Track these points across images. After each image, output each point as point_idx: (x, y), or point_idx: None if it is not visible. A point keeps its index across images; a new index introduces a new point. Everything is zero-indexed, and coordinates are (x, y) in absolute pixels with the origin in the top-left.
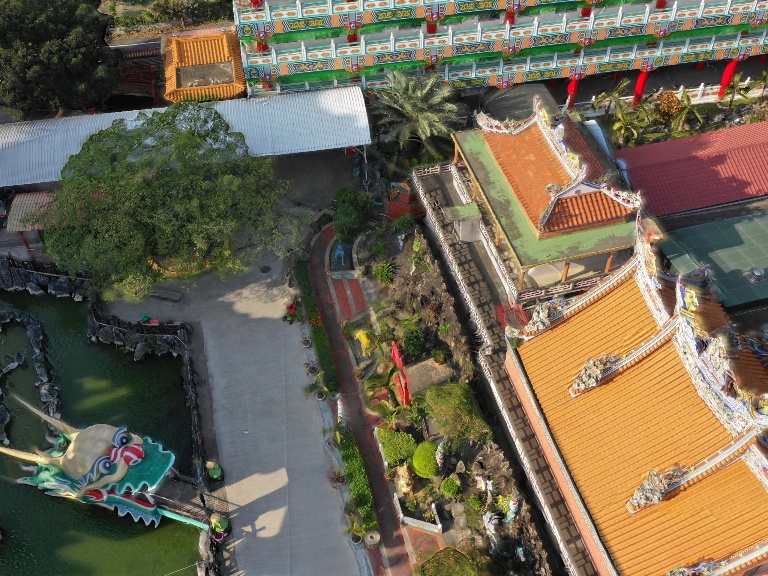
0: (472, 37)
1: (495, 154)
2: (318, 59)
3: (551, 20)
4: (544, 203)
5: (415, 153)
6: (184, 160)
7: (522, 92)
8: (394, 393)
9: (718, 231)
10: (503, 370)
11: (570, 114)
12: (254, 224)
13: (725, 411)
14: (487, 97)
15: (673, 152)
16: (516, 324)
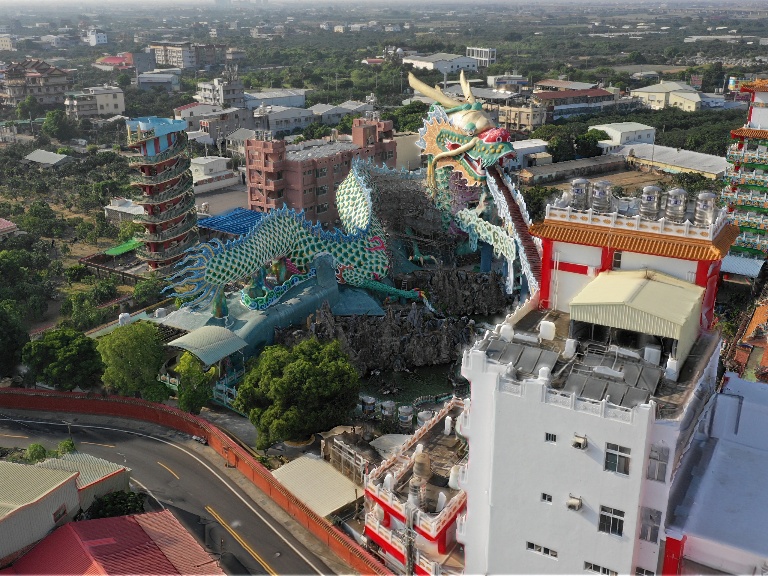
0: None
1: None
2: (750, 242)
3: None
4: None
5: None
6: None
7: None
8: None
9: None
10: None
11: None
12: None
13: None
14: None
15: None
16: None
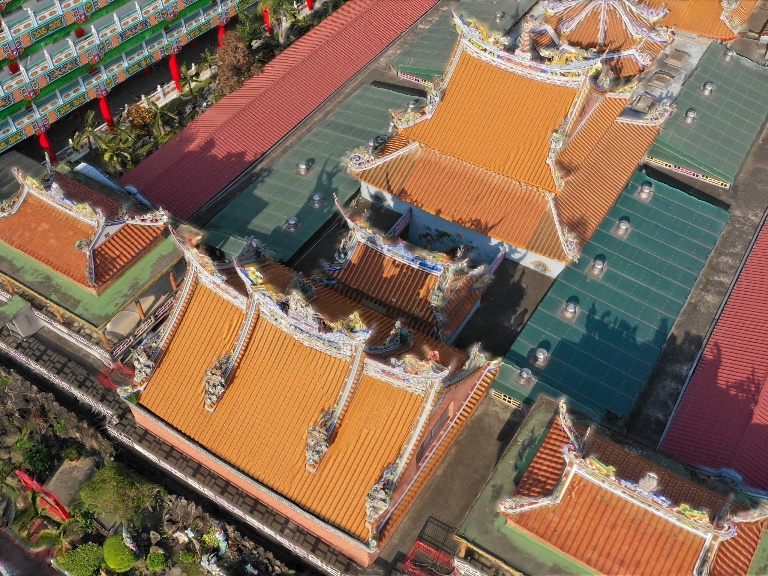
0: None
1: (7, 241)
2: None
3: None
4: (82, 261)
5: None
6: None
7: None
8: (49, 517)
9: (244, 204)
10: (139, 428)
11: (57, 168)
12: None
13: (332, 346)
14: None
15: (169, 157)
16: (125, 381)
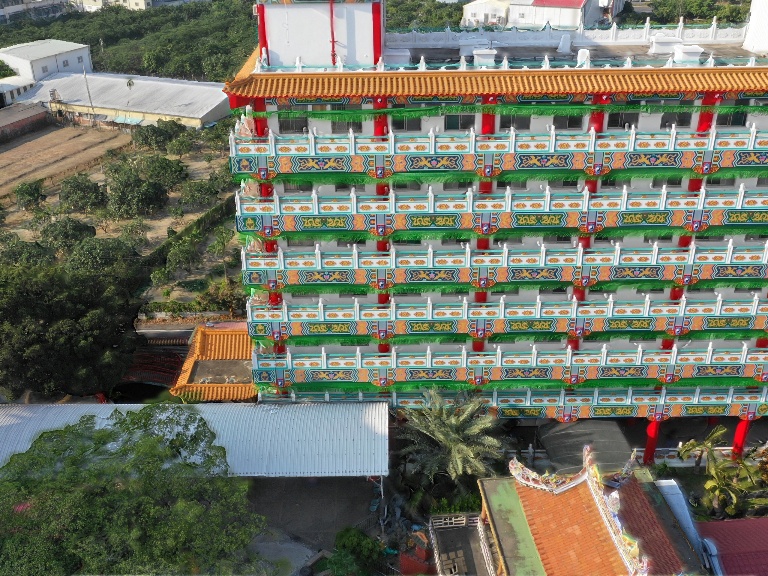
0: (525, 360)
1: (528, 518)
2: (340, 368)
3: (623, 349)
4: None
5: (449, 490)
6: (139, 476)
7: (587, 429)
8: None
9: None
10: None
11: (638, 471)
12: (210, 569)
13: None
14: (544, 431)
15: None
16: None
